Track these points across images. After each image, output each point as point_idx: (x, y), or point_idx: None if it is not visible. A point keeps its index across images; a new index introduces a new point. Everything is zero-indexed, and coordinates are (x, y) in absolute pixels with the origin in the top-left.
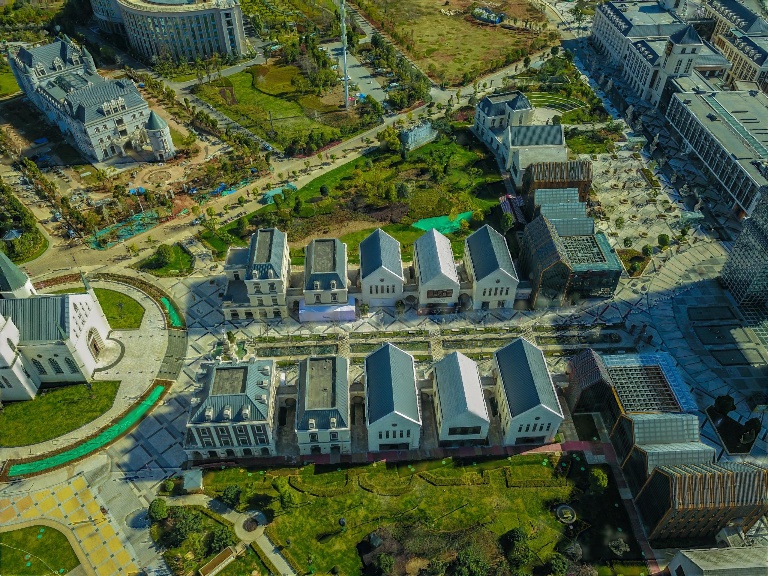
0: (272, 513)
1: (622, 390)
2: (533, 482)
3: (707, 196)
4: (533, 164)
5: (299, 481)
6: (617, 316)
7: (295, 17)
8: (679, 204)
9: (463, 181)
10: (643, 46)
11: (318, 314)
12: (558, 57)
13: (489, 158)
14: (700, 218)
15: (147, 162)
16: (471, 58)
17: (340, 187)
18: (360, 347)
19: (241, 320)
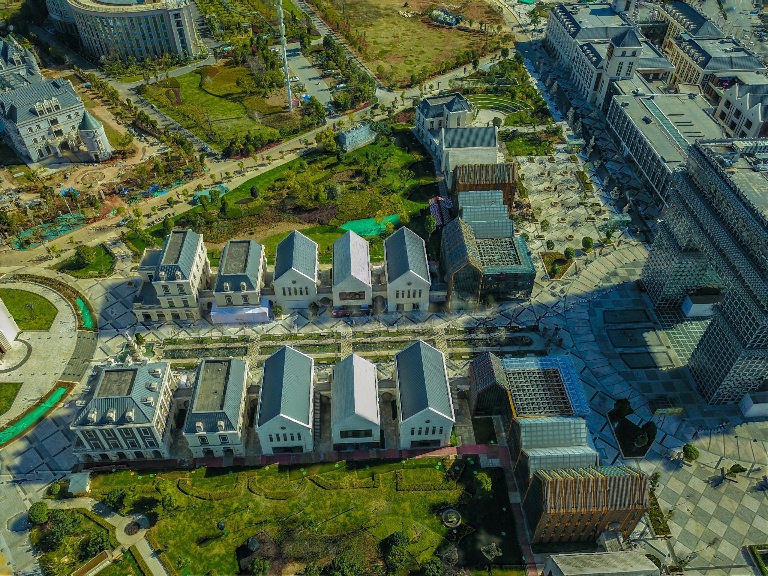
0: (156, 517)
1: (517, 393)
2: (423, 486)
3: (639, 199)
4: (458, 166)
5: (188, 484)
6: (532, 319)
7: (252, 18)
8: (610, 207)
9: (397, 183)
10: (589, 49)
11: (230, 316)
12: (509, 59)
13: (426, 160)
14: (627, 221)
15: (82, 162)
16: (422, 60)
17: (272, 188)
18: (270, 349)
19: (154, 322)
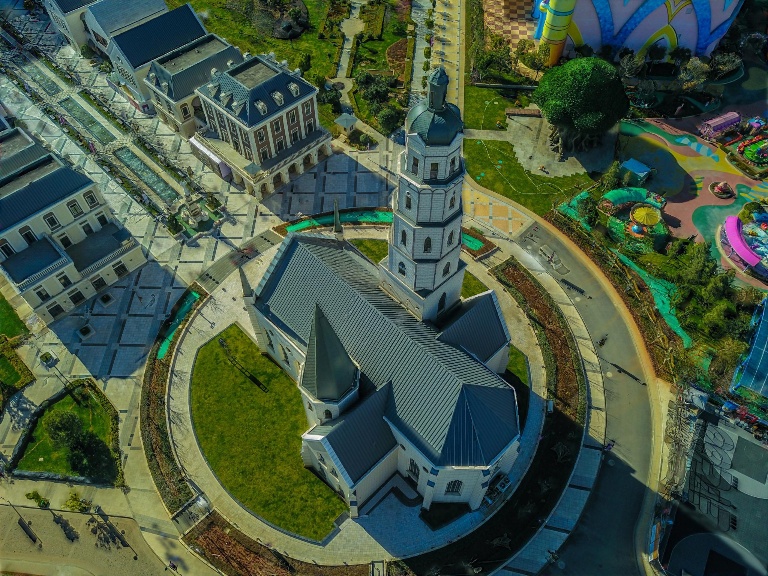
0: None
1: None
2: (171, 2)
3: None
4: None
5: None
6: None
7: None
8: None
9: None
10: None
11: None
12: None
13: None
14: None
15: None
16: None
17: None
18: (103, 139)
19: None
